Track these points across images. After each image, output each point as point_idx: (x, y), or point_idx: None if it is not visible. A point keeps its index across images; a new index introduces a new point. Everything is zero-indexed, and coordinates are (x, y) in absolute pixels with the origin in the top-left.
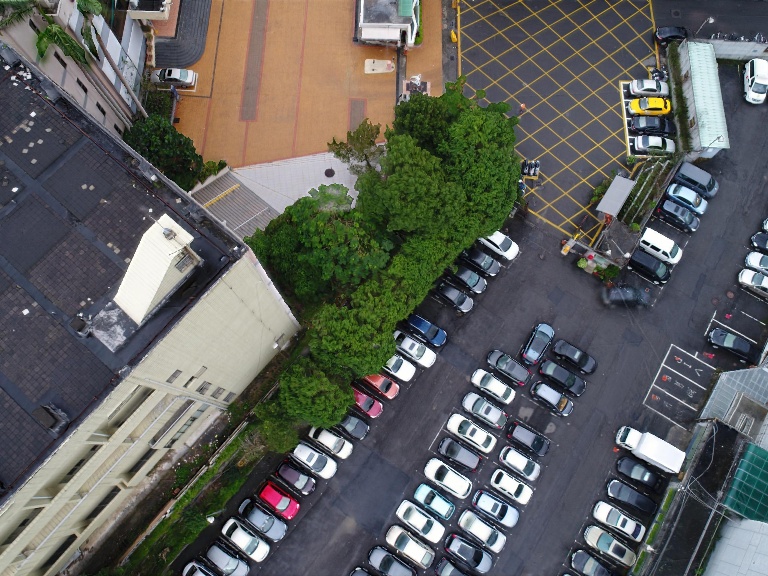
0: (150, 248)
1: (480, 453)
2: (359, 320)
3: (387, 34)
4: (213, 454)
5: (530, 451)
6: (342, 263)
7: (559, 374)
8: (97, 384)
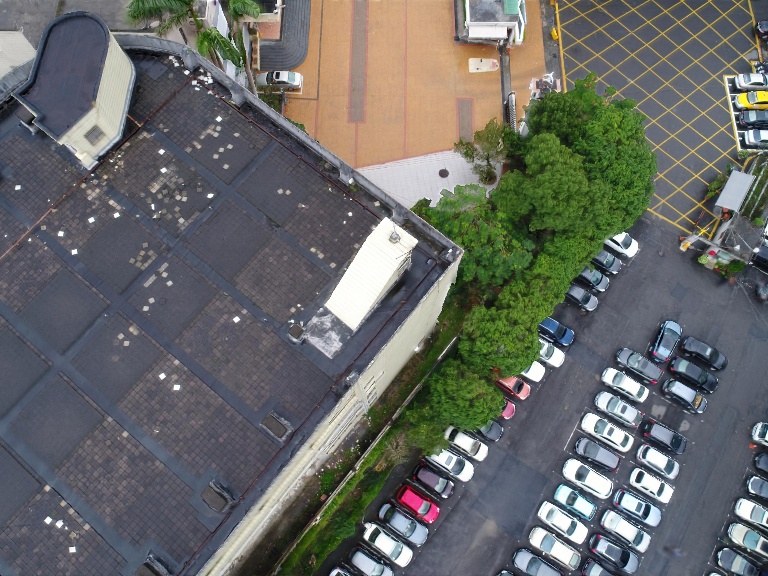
0: (374, 252)
1: (616, 452)
2: (508, 321)
3: (494, 32)
4: (359, 459)
5: (668, 449)
6: (484, 264)
7: (692, 371)
8: (317, 391)
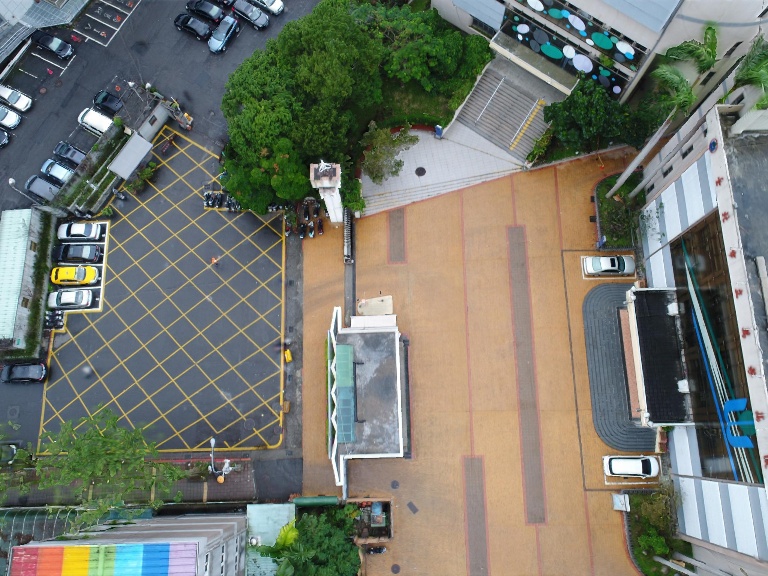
0: None
1: None
2: None
3: (366, 322)
4: None
5: None
6: None
7: (208, 7)
8: None
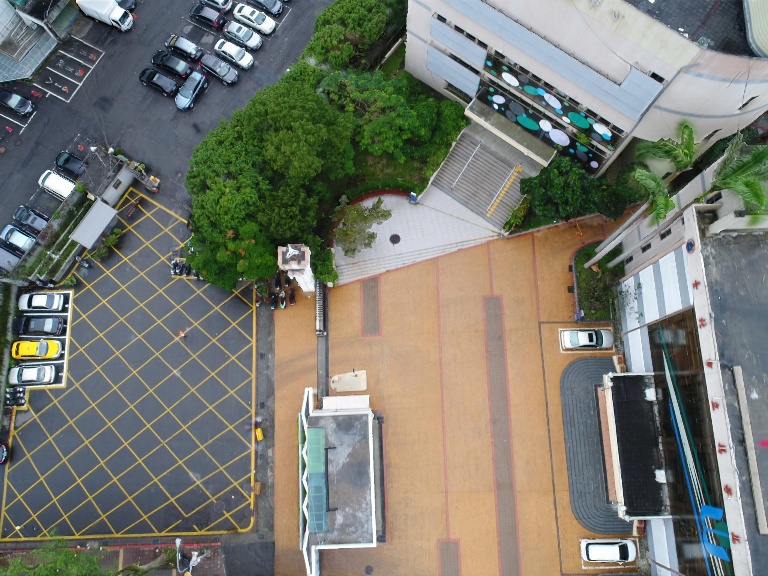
0: None
1: None
2: None
3: (338, 403)
4: None
5: None
6: None
7: (174, 62)
8: None
